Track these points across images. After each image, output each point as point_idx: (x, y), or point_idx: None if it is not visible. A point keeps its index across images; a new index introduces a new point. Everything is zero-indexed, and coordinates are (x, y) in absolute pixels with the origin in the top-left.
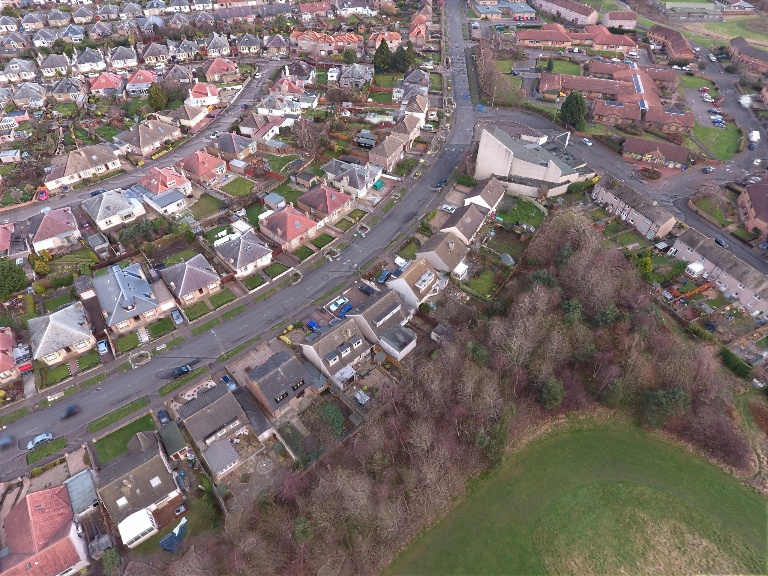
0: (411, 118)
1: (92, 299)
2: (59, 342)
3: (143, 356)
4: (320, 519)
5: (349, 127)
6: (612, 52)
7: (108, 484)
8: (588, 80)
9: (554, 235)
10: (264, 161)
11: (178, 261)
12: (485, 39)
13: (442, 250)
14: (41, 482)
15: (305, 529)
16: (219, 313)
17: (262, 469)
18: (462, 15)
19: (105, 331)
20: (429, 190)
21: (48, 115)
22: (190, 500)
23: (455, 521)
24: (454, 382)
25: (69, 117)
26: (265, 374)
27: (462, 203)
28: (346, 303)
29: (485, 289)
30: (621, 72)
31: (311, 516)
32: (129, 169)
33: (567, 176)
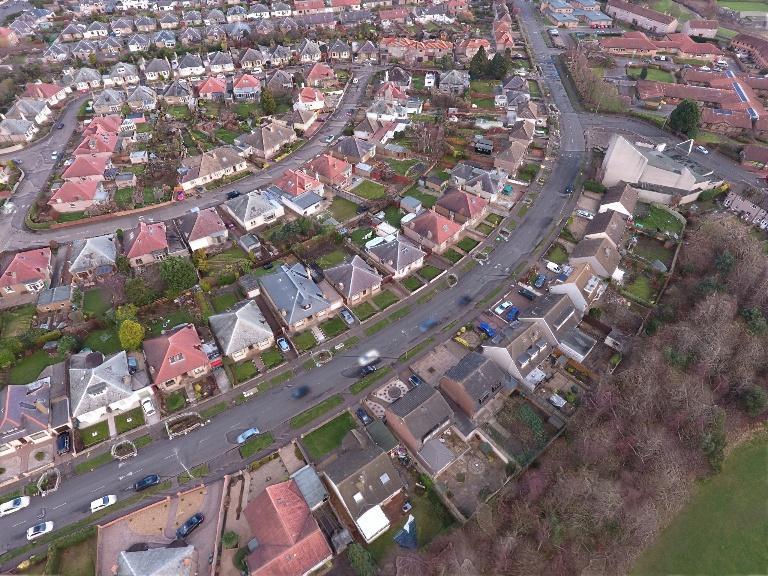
0: (528, 124)
1: (257, 298)
2: (247, 339)
3: (324, 355)
4: (574, 520)
5: (461, 132)
6: (699, 60)
7: (345, 479)
8: (689, 88)
9: (710, 242)
10: (386, 165)
11: (331, 262)
12: (569, 47)
13: (601, 255)
14: (261, 476)
15: (561, 530)
16: (386, 314)
17: (475, 469)
18: (538, 23)
19: (283, 329)
20: (558, 196)
21: (163, 118)
22: (412, 498)
23: (682, 527)
24: (663, 387)
25: (183, 120)
26: (466, 375)
27: (595, 209)
28: (511, 306)
29: (644, 295)
30: (719, 80)
31: (562, 517)
32: (255, 171)
33: (699, 184)
